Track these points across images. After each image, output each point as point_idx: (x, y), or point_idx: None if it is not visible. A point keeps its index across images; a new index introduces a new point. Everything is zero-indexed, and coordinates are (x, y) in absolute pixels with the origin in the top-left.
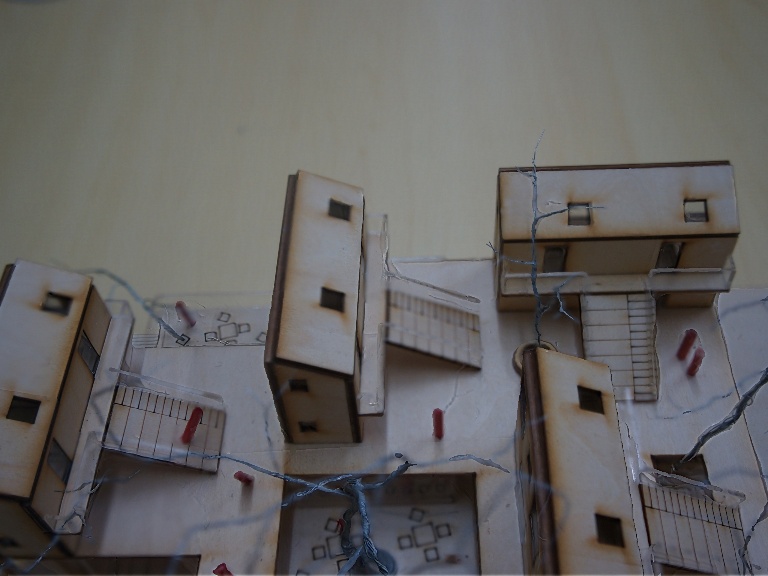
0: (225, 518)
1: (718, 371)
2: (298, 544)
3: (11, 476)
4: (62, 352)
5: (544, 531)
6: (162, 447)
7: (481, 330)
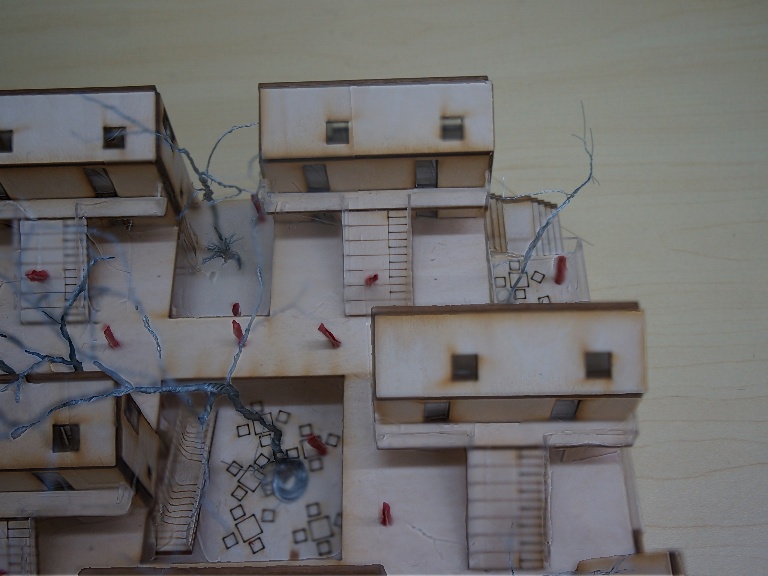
0: (302, 330)
1: None
2: (314, 411)
3: (277, 141)
4: (402, 147)
5: (171, 571)
6: (357, 262)
7: (526, 571)
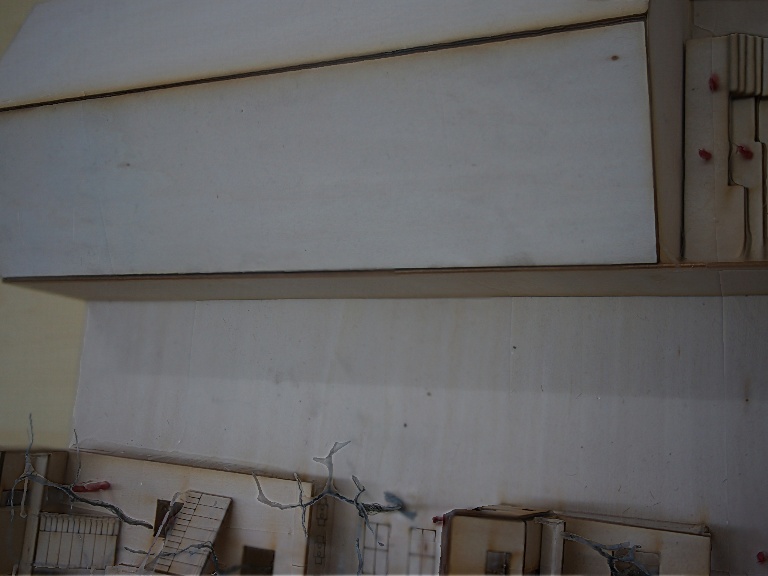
0: None
1: (110, 466)
2: None
3: None
4: None
5: None
6: None
7: None
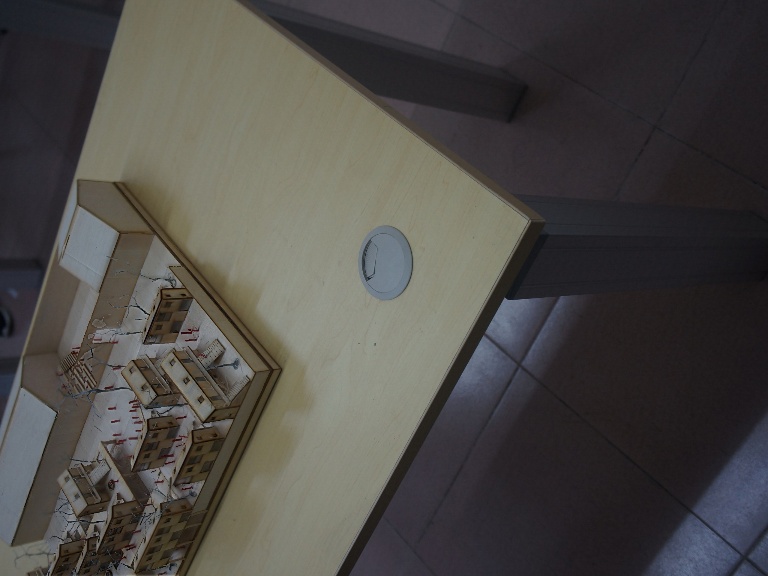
0: None
1: None
2: None
3: None
4: None
5: (56, 567)
6: None
7: None
